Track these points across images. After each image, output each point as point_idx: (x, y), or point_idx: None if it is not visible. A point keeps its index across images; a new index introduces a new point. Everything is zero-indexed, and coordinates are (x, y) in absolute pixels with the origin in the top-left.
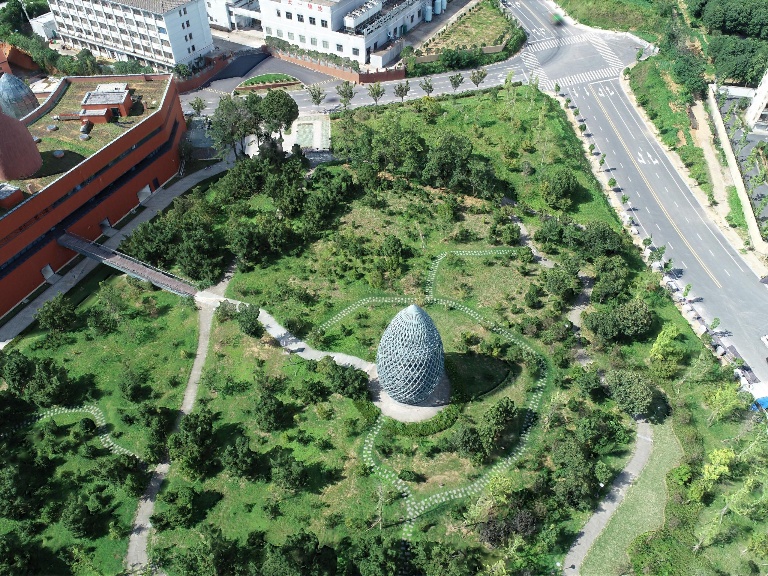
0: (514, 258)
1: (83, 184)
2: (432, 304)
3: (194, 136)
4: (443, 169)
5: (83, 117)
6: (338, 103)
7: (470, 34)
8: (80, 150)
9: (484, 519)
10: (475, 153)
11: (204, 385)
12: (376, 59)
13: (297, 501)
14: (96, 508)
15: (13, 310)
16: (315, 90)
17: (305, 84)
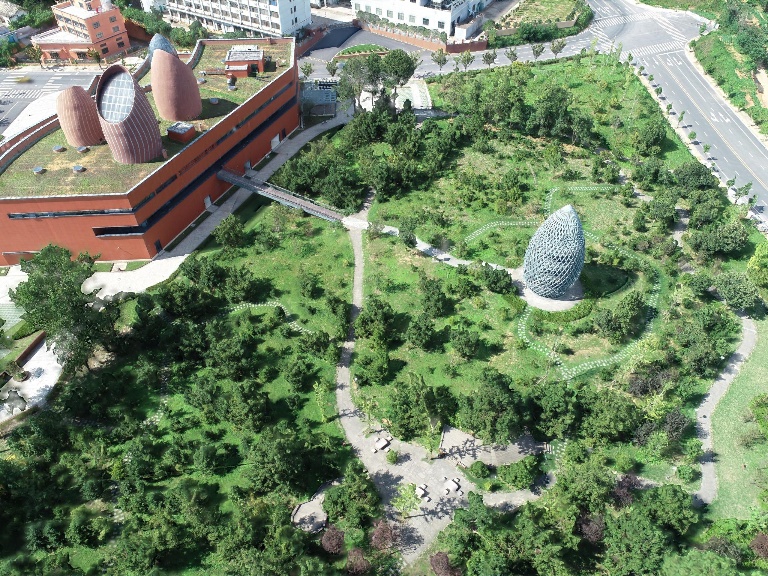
0: (616, 193)
1: (237, 127)
2: None
3: (310, 95)
4: (545, 120)
5: (228, 71)
6: (429, 70)
7: (541, 11)
8: (231, 98)
9: (626, 382)
10: None
11: (374, 282)
12: (461, 32)
13: (470, 366)
14: (303, 371)
15: (184, 232)
16: (412, 57)
17: None
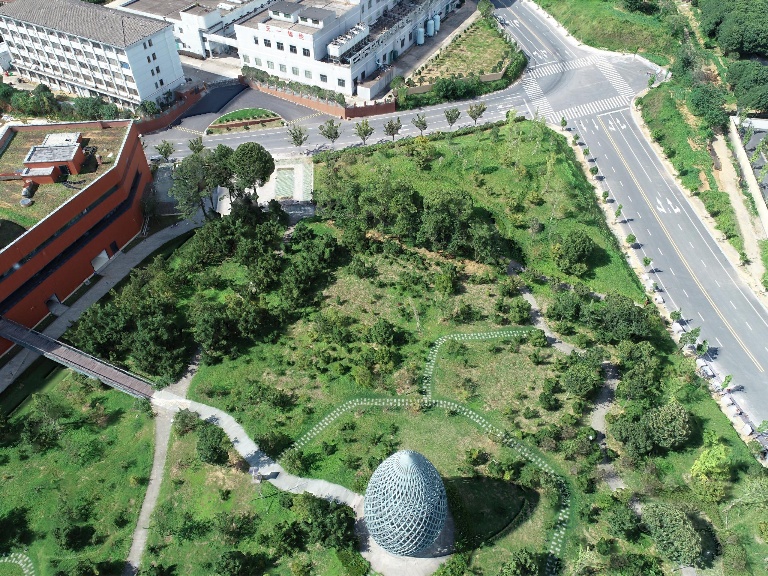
0: (524, 341)
1: (22, 261)
2: (430, 408)
3: (159, 188)
4: (440, 231)
5: (26, 177)
6: (322, 142)
7: (466, 59)
8: (20, 219)
9: None
10: (475, 206)
11: (155, 531)
12: (364, 91)
13: None
14: None
15: None
16: (296, 130)
17: (286, 120)
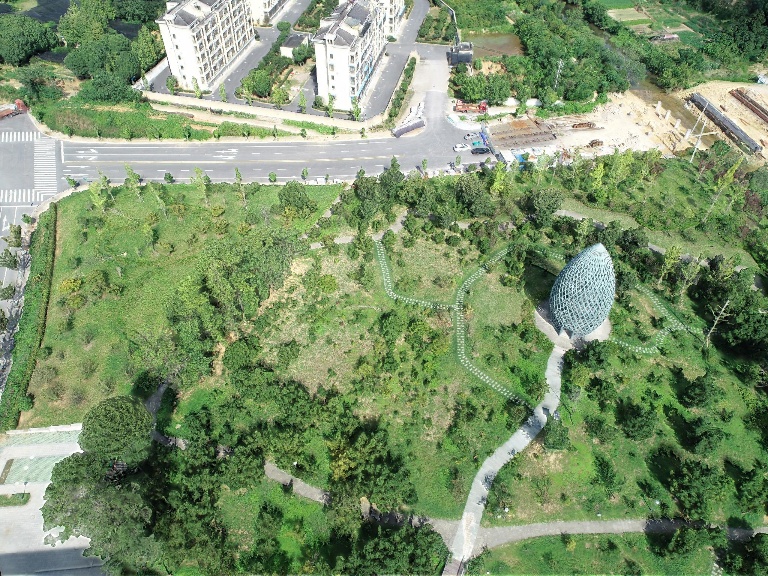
0: None
1: None
2: (465, 306)
3: None
4: None
5: None
6: None
7: None
8: None
9: (667, 290)
10: None
11: None
12: None
13: None
14: None
15: None
16: None
17: None
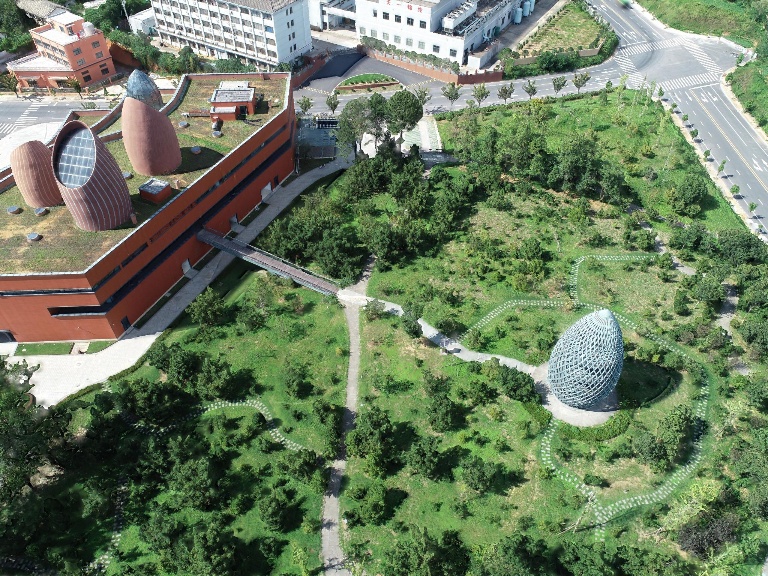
0: (651, 264)
1: (221, 181)
2: (580, 308)
3: (307, 135)
4: None
5: (214, 114)
6: (439, 104)
7: (562, 37)
8: (216, 147)
9: (674, 526)
10: None
11: None
12: (474, 61)
13: (484, 502)
14: (283, 502)
15: (157, 303)
16: (420, 91)
17: (404, 84)
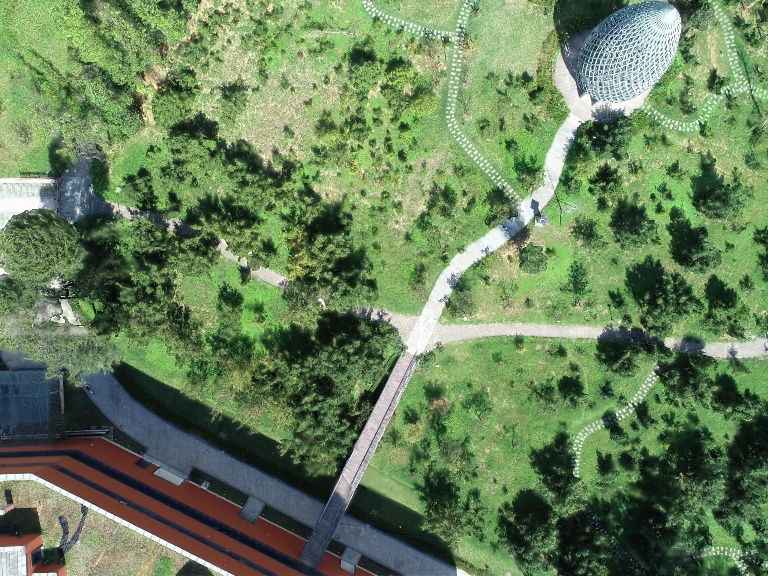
0: None
1: None
2: (467, 34)
3: (12, 423)
4: None
5: None
6: None
7: None
8: None
9: (754, 18)
10: None
11: None
12: None
13: None
14: None
15: None
16: None
17: None
